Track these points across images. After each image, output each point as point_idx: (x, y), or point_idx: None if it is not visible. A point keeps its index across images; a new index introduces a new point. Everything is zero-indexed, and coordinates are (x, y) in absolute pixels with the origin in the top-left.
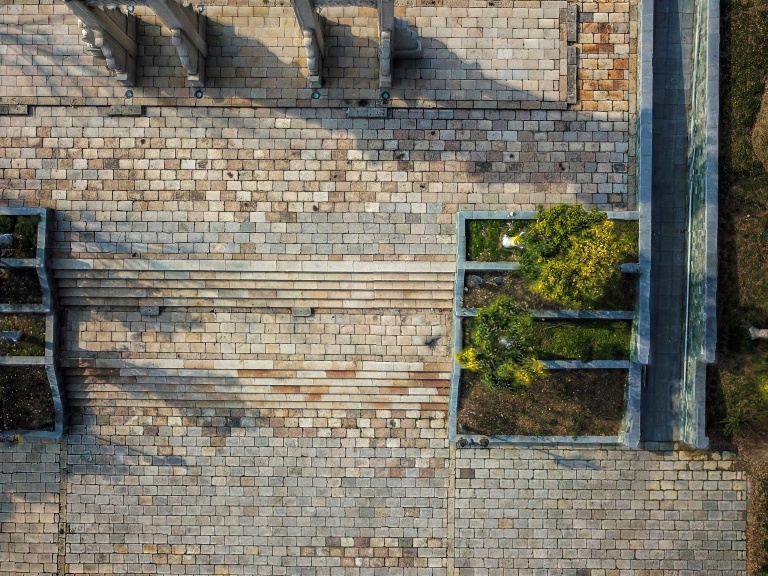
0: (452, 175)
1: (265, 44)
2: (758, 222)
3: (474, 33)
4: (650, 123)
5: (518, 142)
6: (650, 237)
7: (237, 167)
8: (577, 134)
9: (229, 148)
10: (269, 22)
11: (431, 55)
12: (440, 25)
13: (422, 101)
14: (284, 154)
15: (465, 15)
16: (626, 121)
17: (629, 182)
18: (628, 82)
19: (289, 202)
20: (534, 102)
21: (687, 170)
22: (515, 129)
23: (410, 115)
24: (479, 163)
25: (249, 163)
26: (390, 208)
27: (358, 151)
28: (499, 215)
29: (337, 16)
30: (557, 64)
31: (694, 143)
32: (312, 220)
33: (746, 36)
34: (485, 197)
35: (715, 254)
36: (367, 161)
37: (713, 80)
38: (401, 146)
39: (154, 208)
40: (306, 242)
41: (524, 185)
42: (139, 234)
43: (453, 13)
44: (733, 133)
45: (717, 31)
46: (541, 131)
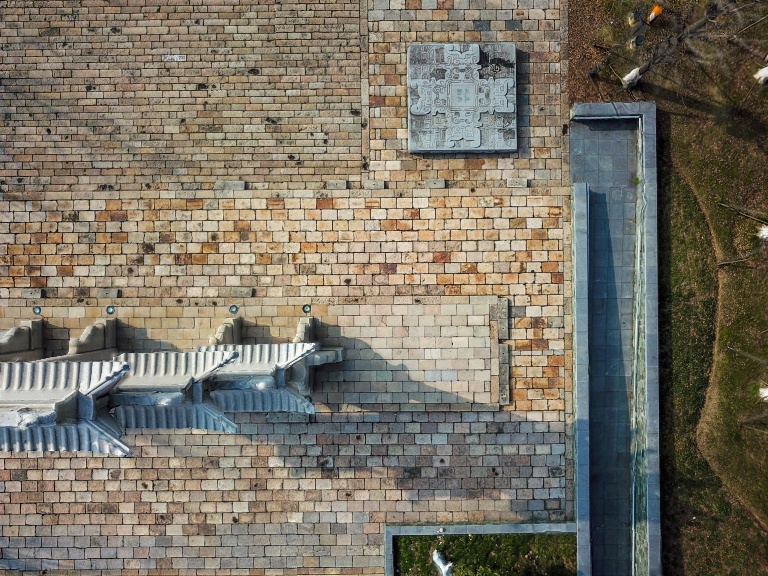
0: (379, 482)
1: (179, 347)
2: (705, 525)
3: (400, 332)
4: (587, 430)
5: (449, 445)
6: (589, 552)
7: (152, 477)
8: (511, 437)
9: (143, 456)
10: (183, 323)
11: (355, 356)
12: (364, 324)
13: (346, 405)
14: (201, 463)
15: (390, 313)
16: (562, 421)
17: (567, 486)
18: (564, 380)
19: (207, 513)
20: (464, 404)
21: (630, 461)
22: (445, 432)
23: (334, 419)
24: (408, 469)
25: (164, 472)
26: (314, 518)
27: (279, 458)
28: (428, 531)
29: (255, 316)
30: (488, 364)
31: (636, 439)
32: (232, 532)
33: (688, 328)
34: (414, 505)
35: (658, 569)
36: (289, 468)
37: (652, 383)
38: (325, 452)
39: (65, 522)
40: (226, 556)
41: (455, 492)
42: (49, 550)
43: (377, 311)
44: (676, 431)
45: (656, 331)
46: (473, 433)
